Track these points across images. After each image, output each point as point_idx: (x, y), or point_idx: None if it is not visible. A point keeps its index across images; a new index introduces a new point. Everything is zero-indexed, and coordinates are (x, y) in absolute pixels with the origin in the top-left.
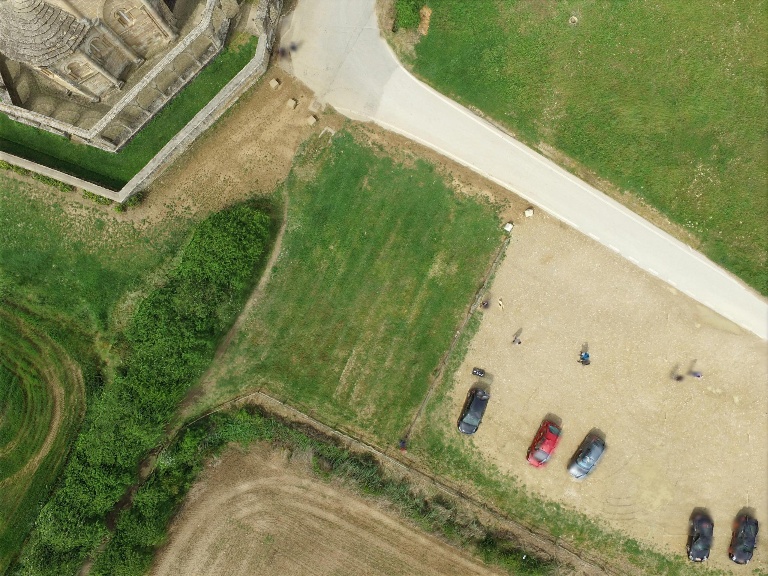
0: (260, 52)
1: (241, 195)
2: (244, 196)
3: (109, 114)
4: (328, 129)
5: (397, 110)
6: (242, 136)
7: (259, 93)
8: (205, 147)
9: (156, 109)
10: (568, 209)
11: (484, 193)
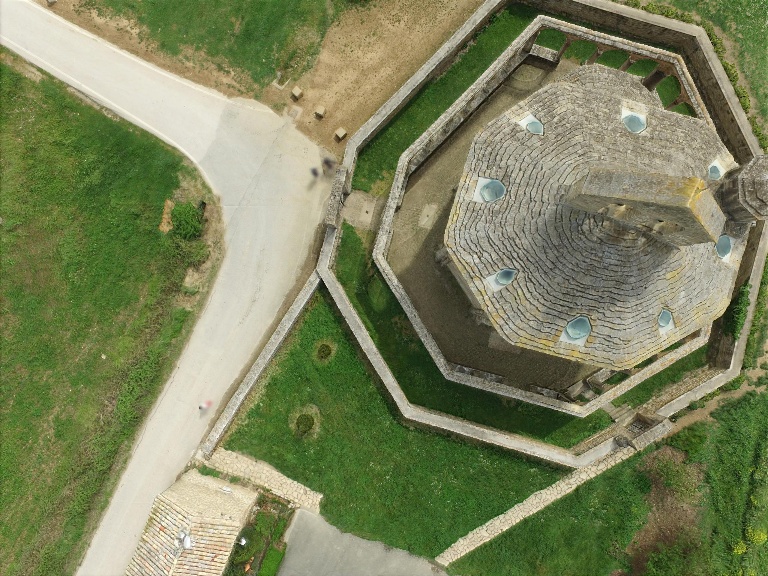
0: (350, 153)
1: (380, 5)
2: (377, 4)
3: (517, 43)
4: (280, 87)
5: (201, 111)
6: (379, 74)
7: (360, 125)
8: (422, 60)
9: (477, 95)
10: (8, 4)
11: (103, 20)
